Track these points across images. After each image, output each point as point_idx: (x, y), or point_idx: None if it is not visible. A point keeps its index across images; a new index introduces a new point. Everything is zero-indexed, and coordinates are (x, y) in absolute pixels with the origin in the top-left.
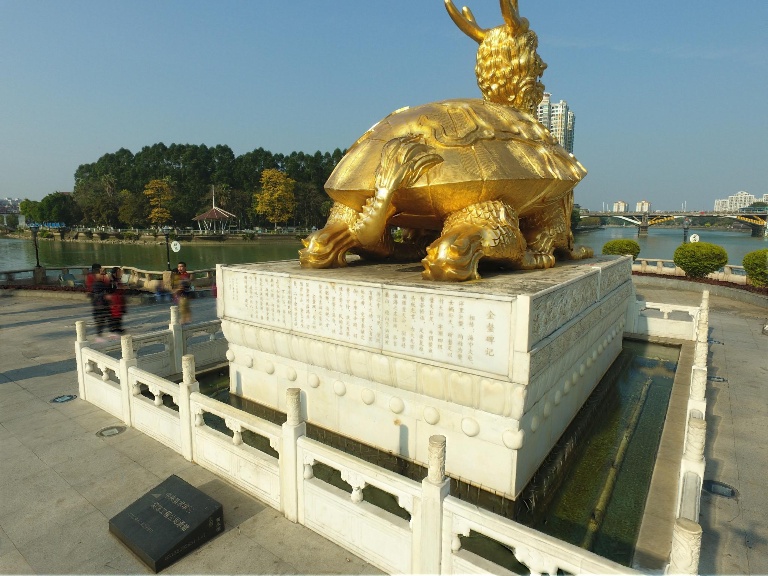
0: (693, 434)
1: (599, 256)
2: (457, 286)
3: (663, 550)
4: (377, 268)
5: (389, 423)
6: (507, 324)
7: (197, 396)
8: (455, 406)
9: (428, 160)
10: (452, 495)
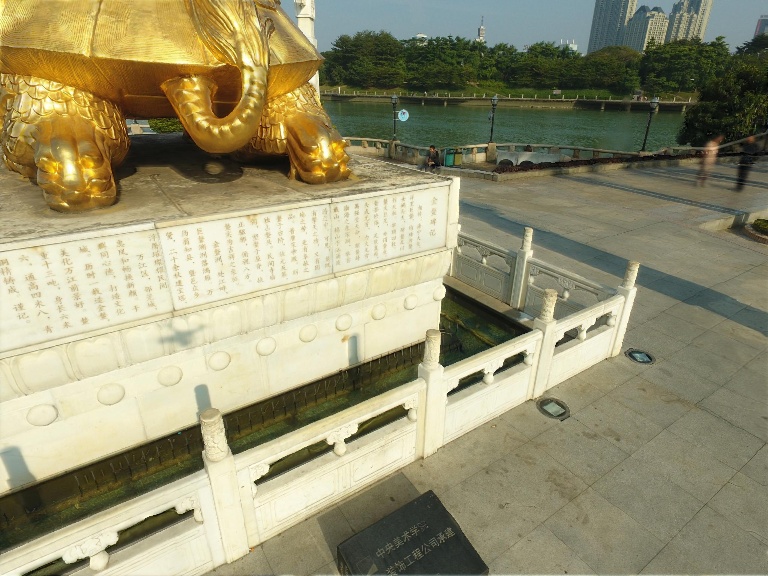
0: (530, 236)
1: None
2: (376, 183)
3: (507, 307)
4: (166, 185)
5: (336, 345)
6: (445, 204)
7: (254, 455)
8: (399, 292)
9: (270, 27)
10: (414, 360)
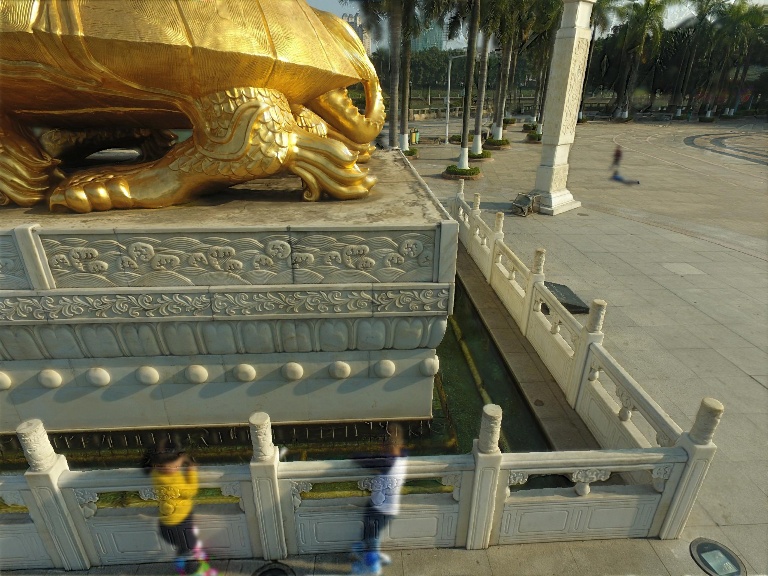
0: None
1: None
2: None
3: None
4: None
5: None
6: None
7: None
8: None
9: None
10: None
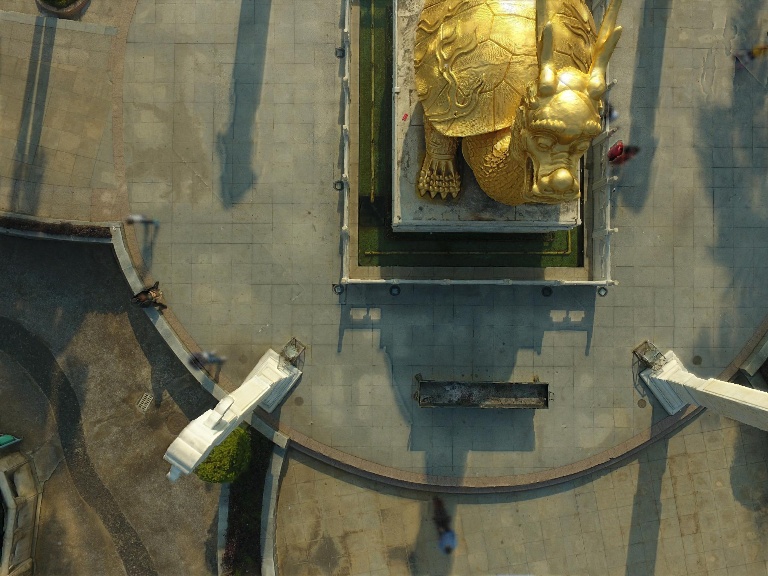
0: None
1: (417, 206)
2: None
3: (353, 8)
4: None
5: None
6: None
7: None
8: None
9: None
10: None
